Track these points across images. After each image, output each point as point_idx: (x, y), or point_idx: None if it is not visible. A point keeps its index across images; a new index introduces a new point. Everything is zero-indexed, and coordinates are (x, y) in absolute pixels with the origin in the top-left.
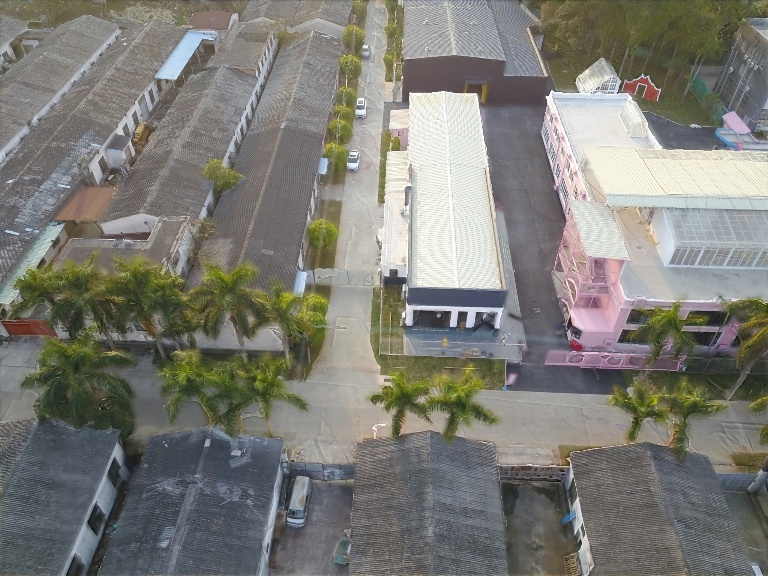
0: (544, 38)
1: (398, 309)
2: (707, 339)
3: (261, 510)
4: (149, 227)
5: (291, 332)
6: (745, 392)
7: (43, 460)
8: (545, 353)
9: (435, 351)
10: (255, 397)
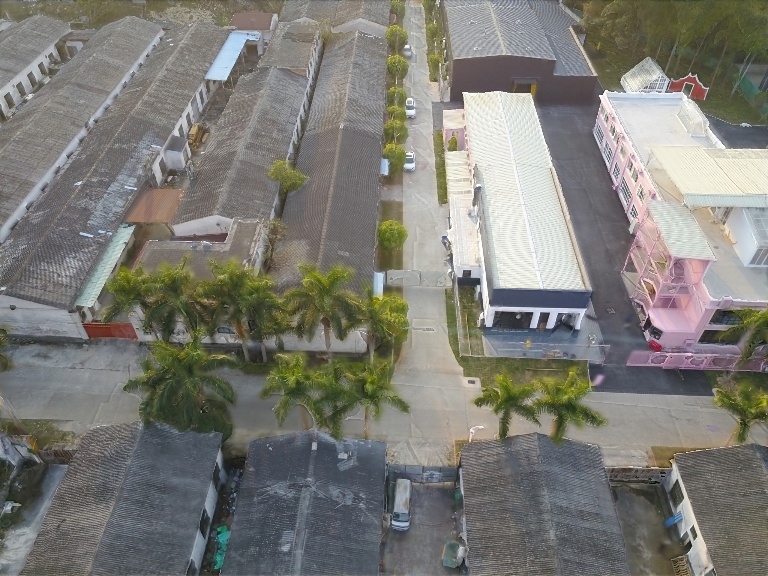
0: (586, 37)
1: (473, 310)
2: None
3: (374, 513)
4: (221, 229)
5: None
6: None
7: (152, 464)
8: (625, 354)
9: (516, 352)
10: (360, 400)
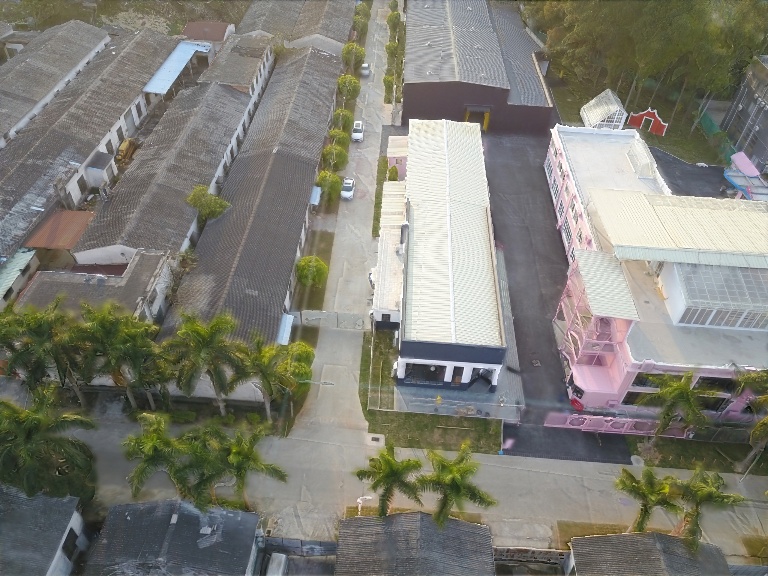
0: (549, 64)
1: (389, 357)
2: (716, 404)
3: None
4: (126, 258)
5: (273, 387)
6: (755, 465)
7: None
8: (544, 412)
9: (427, 407)
10: None
